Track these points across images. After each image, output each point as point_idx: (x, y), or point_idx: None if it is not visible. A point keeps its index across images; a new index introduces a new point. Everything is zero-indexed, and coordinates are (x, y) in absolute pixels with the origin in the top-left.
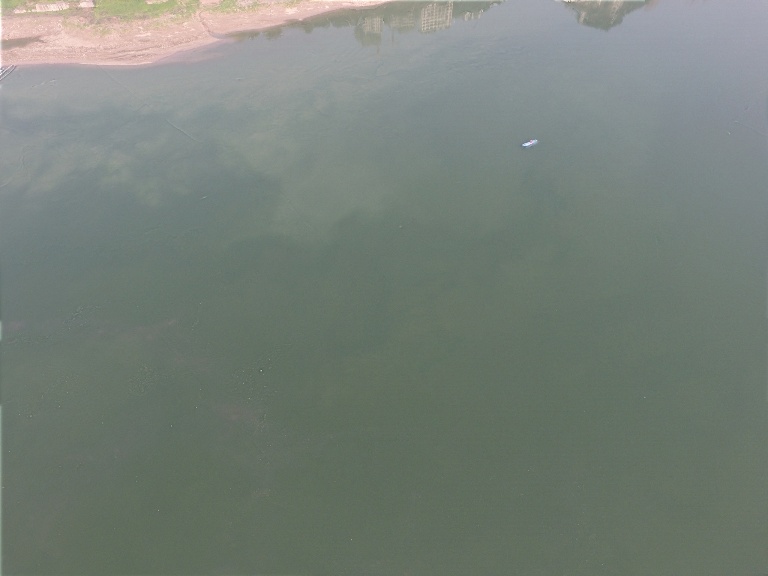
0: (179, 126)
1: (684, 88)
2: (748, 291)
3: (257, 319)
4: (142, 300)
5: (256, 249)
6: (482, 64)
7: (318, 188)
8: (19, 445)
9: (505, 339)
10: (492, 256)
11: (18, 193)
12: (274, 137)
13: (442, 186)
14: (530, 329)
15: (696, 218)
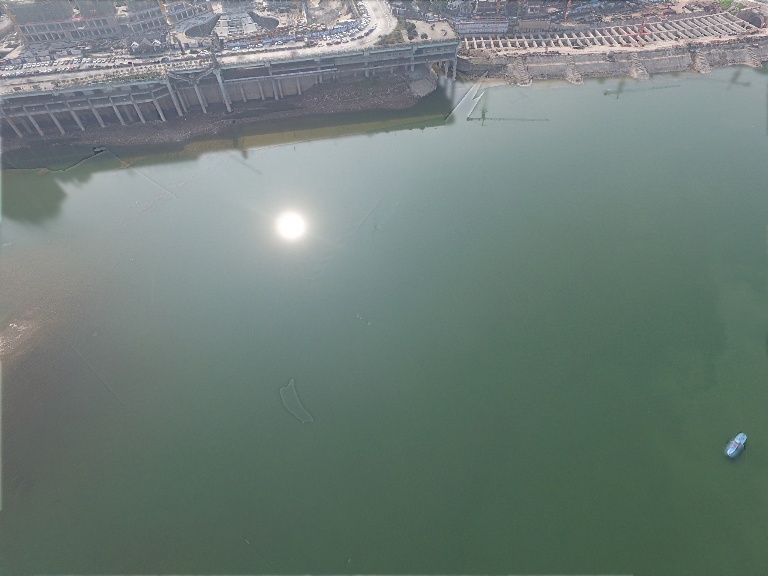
0: None
1: None
2: (457, 248)
3: None
4: None
5: None
6: None
7: None
8: None
9: (658, 198)
10: (700, 257)
11: None
12: None
13: None
14: (643, 201)
15: (477, 335)
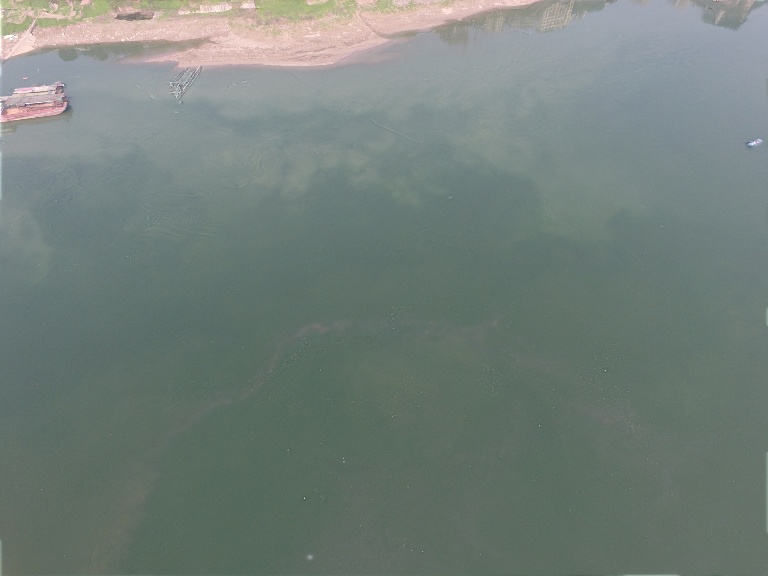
0: (387, 126)
1: None
2: None
3: (577, 319)
4: (452, 300)
5: (536, 249)
6: (659, 63)
7: (559, 188)
8: (398, 445)
9: None
10: None
11: (261, 194)
12: (490, 137)
13: (683, 186)
14: None
15: None
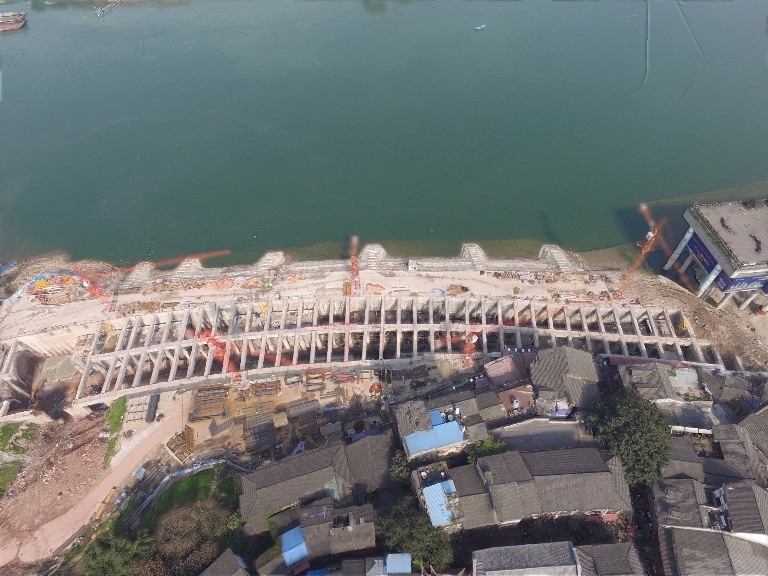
0: (240, 30)
1: None
2: None
3: (300, 105)
4: (231, 100)
5: (297, 79)
6: None
7: (336, 55)
8: (172, 154)
9: (450, 112)
10: (447, 79)
11: (141, 64)
12: (305, 32)
13: (418, 51)
14: (466, 107)
15: (588, 62)
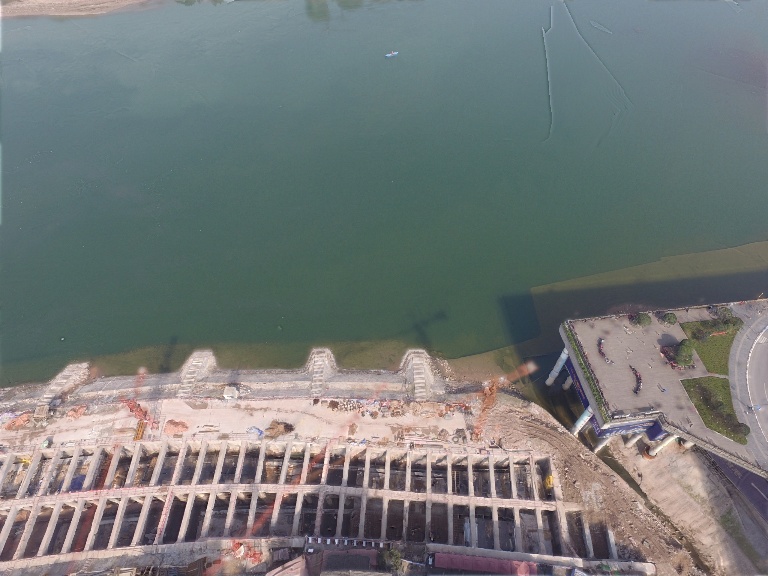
0: (124, 53)
1: (528, 17)
2: (522, 134)
3: (162, 154)
4: (83, 147)
5: (169, 119)
6: (374, 7)
7: (224, 87)
8: None
9: (337, 163)
10: (342, 120)
11: None
12: (197, 57)
13: (318, 82)
14: (355, 156)
15: (505, 97)
